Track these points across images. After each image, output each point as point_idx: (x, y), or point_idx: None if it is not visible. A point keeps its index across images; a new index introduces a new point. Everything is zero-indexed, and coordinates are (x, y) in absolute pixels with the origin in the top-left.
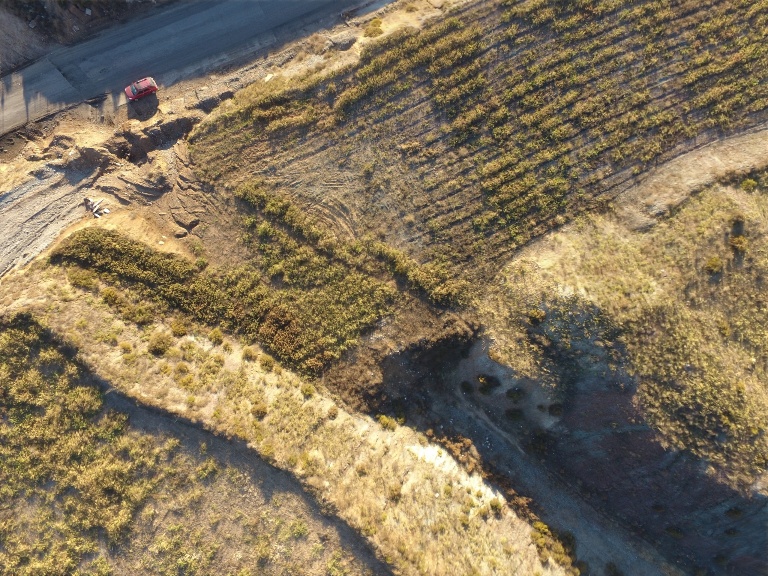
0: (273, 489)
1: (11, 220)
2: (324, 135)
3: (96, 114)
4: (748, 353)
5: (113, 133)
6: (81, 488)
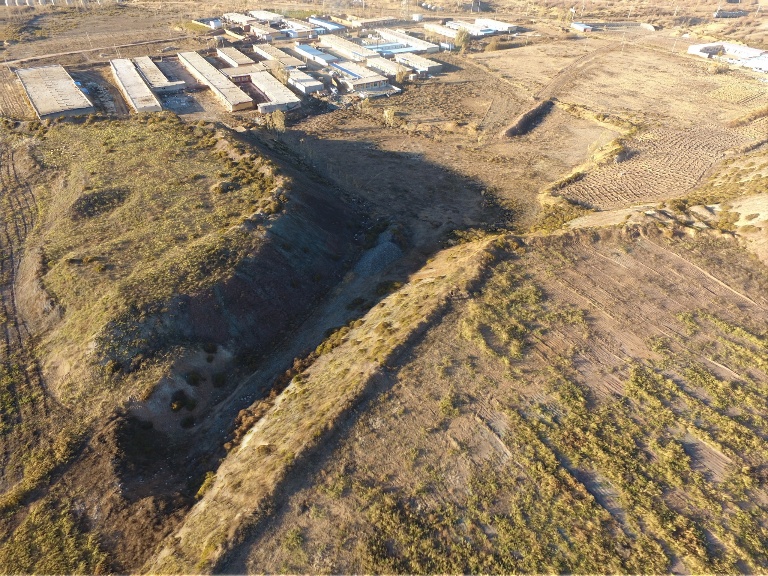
0: None
1: None
2: None
3: None
4: (171, 249)
5: None
6: None
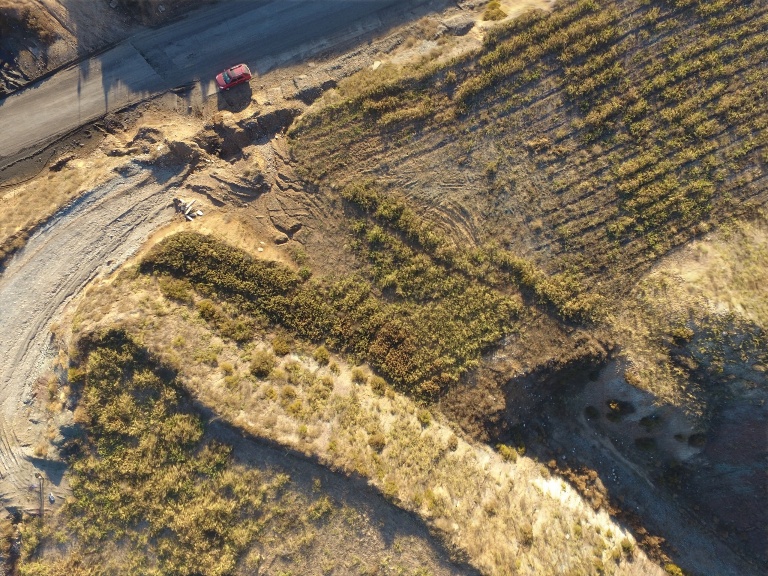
0: (395, 532)
1: (93, 223)
2: (442, 130)
3: (183, 104)
4: None
5: (203, 126)
6: (178, 530)
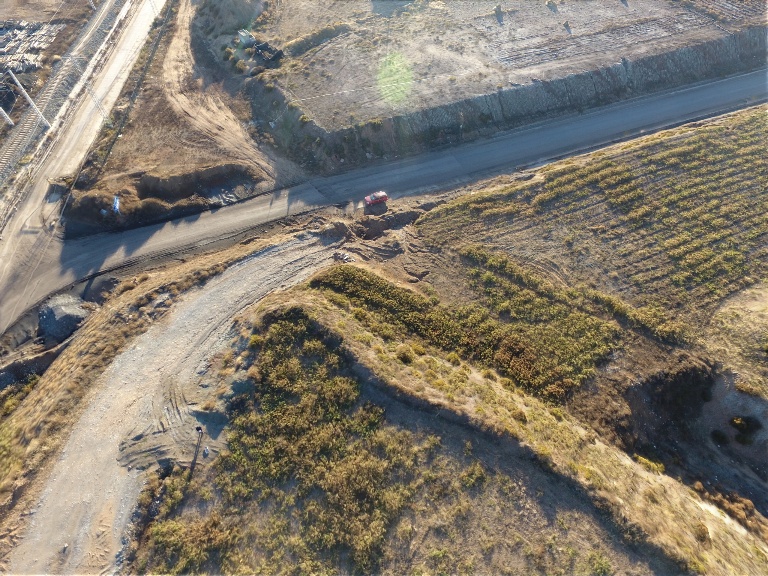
0: (555, 505)
1: (275, 263)
2: (527, 219)
3: (340, 212)
4: None
5: (354, 221)
6: (328, 488)
